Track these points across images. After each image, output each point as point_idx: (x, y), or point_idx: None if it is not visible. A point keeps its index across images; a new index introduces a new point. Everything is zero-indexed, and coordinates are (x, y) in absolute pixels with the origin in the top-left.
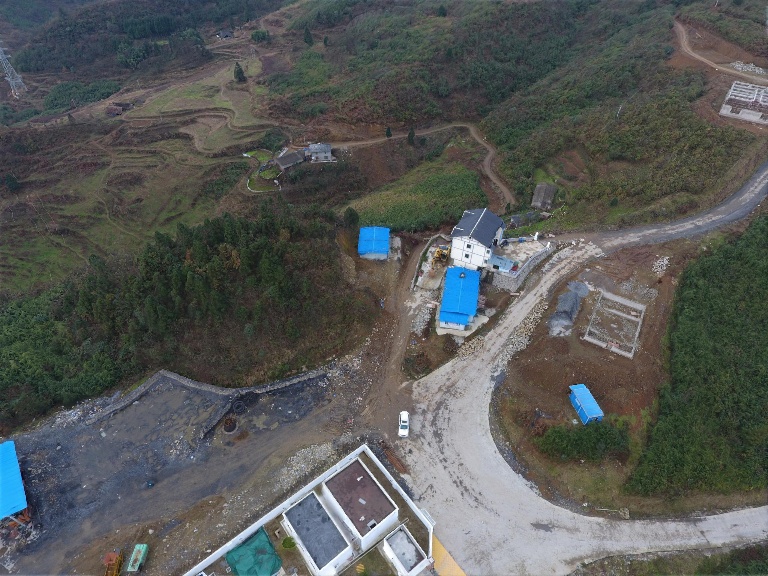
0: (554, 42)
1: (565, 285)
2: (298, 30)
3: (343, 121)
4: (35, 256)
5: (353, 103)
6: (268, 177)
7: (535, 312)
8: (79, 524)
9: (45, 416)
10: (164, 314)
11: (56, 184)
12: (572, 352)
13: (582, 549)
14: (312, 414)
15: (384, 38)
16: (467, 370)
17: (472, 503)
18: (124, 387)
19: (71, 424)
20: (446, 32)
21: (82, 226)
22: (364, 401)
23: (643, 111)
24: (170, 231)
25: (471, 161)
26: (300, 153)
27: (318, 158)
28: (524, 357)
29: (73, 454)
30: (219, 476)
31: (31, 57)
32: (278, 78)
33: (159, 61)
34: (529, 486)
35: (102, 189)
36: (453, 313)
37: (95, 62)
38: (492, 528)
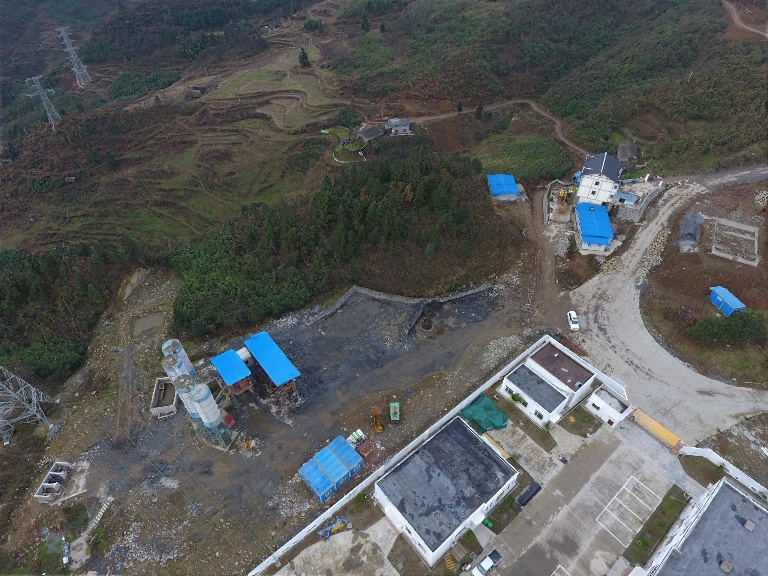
0: (602, 23)
1: (682, 215)
2: (349, 18)
3: (416, 98)
4: (141, 225)
5: (423, 81)
6: (353, 149)
7: (661, 236)
8: (333, 393)
9: (263, 323)
10: (354, 239)
11: (150, 161)
12: (705, 263)
13: (741, 408)
14: (492, 316)
15: (440, 23)
16: (613, 282)
17: (645, 376)
18: (321, 302)
19: (293, 326)
20: (501, 15)
21: (180, 198)
22: (532, 306)
23: (713, 76)
24: (265, 200)
25: (541, 131)
26: (380, 127)
27: (397, 131)
28: (661, 270)
29: (305, 347)
30: (433, 359)
31: (93, 49)
32: (343, 61)
33: (219, 50)
34: (686, 365)
35: (195, 164)
36: (594, 236)
37: (153, 53)
38: (667, 393)
